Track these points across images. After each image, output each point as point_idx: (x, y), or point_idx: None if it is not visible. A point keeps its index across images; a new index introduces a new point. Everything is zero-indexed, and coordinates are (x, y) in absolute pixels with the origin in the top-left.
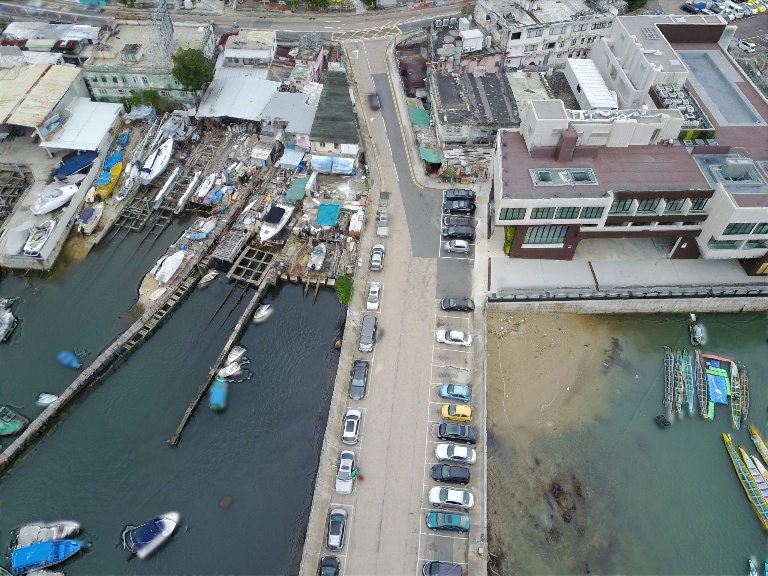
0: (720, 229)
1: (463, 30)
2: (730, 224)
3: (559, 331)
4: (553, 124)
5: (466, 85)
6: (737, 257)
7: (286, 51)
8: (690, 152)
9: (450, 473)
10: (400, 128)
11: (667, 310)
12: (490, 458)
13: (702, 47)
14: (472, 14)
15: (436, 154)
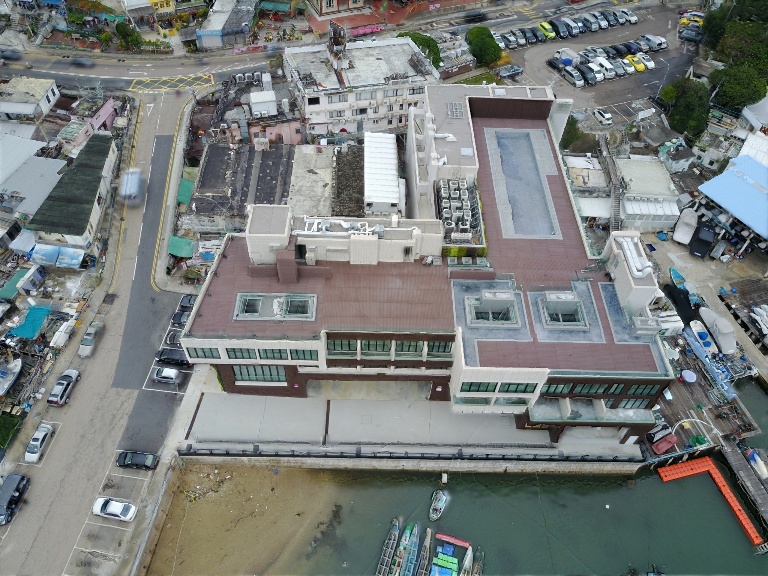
0: (456, 386)
1: (265, 88)
2: (464, 382)
3: (271, 492)
4: (267, 240)
5: (241, 161)
6: (493, 411)
7: (70, 102)
8: None
9: None
10: (162, 208)
11: (413, 468)
12: None
13: (527, 125)
14: (282, 68)
15: (191, 245)
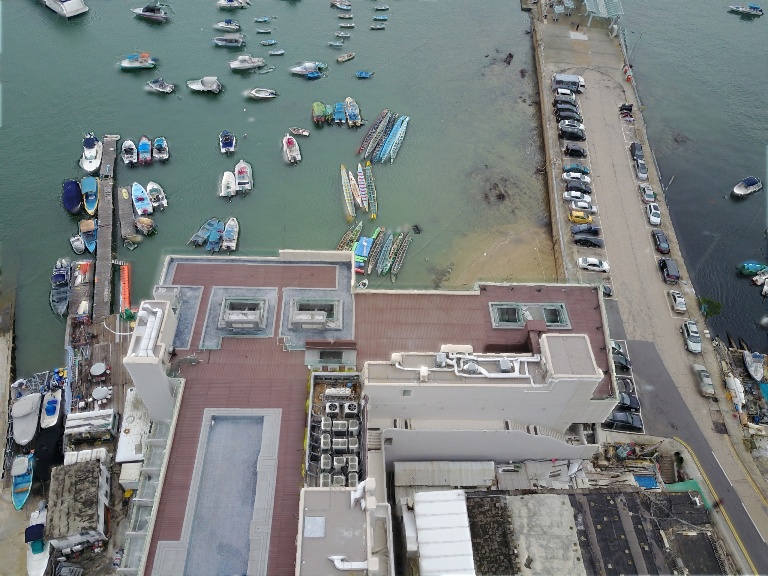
0: None
1: None
2: None
3: None
4: None
5: None
6: None
7: None
8: (354, 355)
9: (581, 184)
10: (758, 571)
11: None
12: (546, 215)
13: None
14: None
15: None
